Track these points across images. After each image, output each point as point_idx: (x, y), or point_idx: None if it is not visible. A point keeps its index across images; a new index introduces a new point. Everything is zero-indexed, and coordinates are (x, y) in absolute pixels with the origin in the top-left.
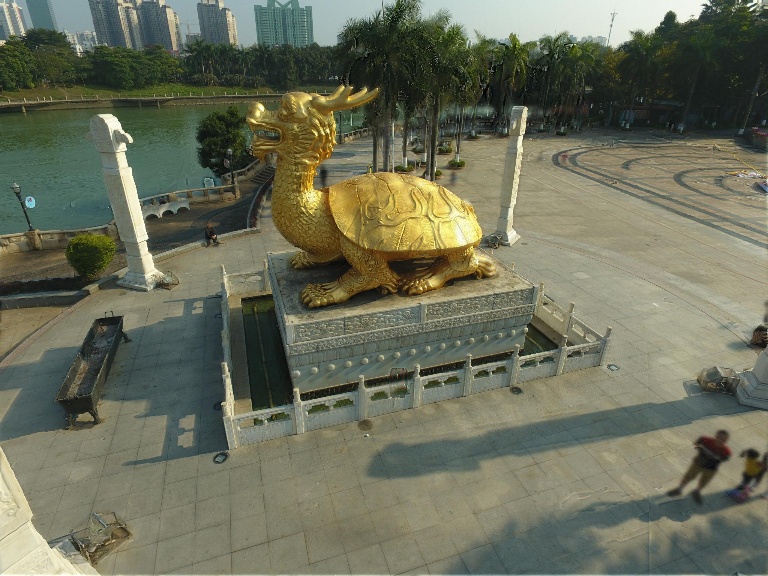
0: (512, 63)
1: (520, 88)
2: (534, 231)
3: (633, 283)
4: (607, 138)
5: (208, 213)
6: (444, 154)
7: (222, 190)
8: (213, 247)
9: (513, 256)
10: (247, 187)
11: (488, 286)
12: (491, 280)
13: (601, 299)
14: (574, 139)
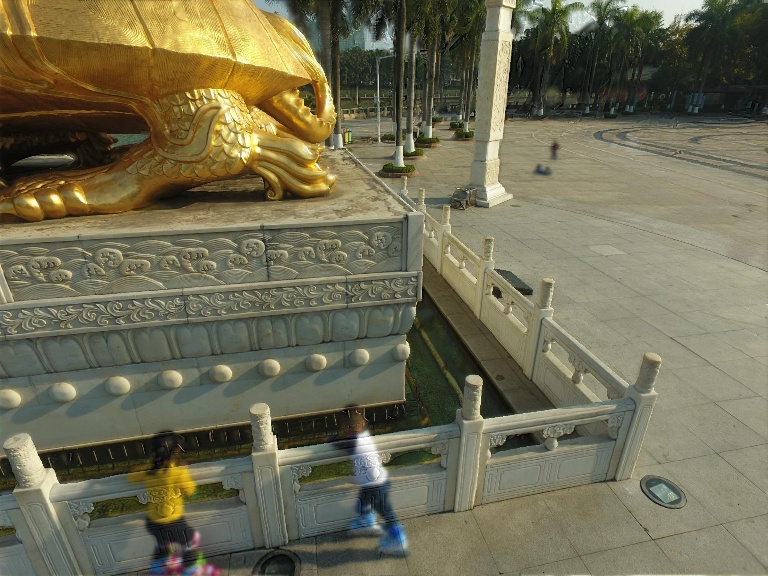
0: (550, 28)
1: (560, 59)
2: (542, 196)
3: (715, 266)
4: (669, 121)
5: None
6: (457, 129)
7: None
8: None
9: (486, 219)
10: None
11: (274, 212)
12: (303, 202)
13: (642, 291)
14: (627, 121)
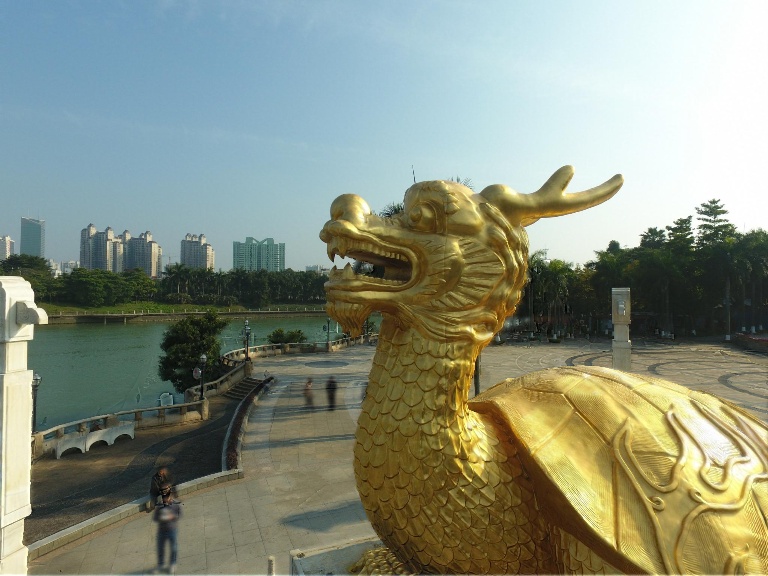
0: None
1: None
2: None
3: None
4: (602, 345)
5: (160, 443)
6: None
7: (185, 409)
8: (161, 511)
9: None
10: (218, 404)
11: None
12: None
13: None
14: (570, 346)
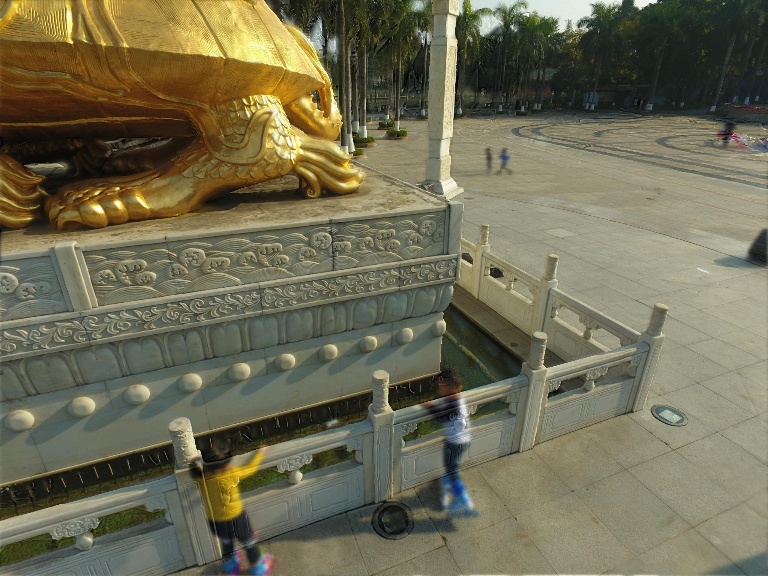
0: None
1: (473, 61)
2: (486, 189)
3: (650, 240)
4: (572, 117)
5: None
6: (385, 129)
7: None
8: None
9: None
10: None
11: (325, 208)
12: (343, 199)
13: (601, 265)
14: (536, 118)
